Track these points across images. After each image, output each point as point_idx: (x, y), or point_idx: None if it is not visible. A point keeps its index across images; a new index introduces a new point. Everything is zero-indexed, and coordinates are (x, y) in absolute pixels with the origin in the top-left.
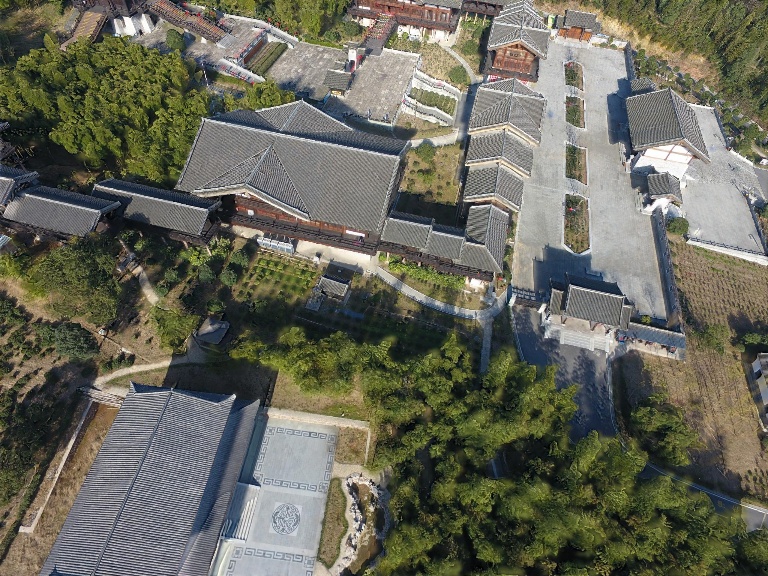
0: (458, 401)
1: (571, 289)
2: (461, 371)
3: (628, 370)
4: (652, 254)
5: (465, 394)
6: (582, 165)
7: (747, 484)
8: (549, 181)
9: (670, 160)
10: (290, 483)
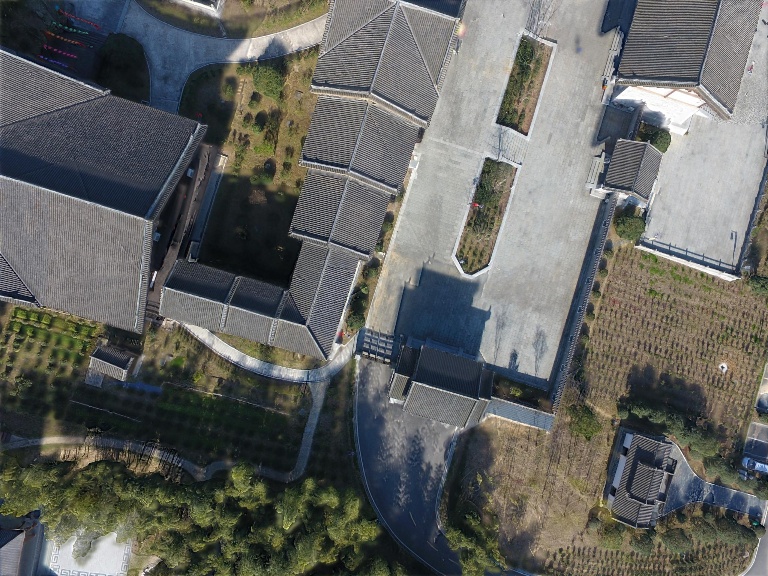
0: (239, 541)
1: (414, 385)
2: (250, 502)
3: (475, 445)
4: (574, 274)
5: (249, 531)
6: (535, 87)
7: (552, 561)
8: (466, 132)
9: (673, 98)
10: (87, 574)
